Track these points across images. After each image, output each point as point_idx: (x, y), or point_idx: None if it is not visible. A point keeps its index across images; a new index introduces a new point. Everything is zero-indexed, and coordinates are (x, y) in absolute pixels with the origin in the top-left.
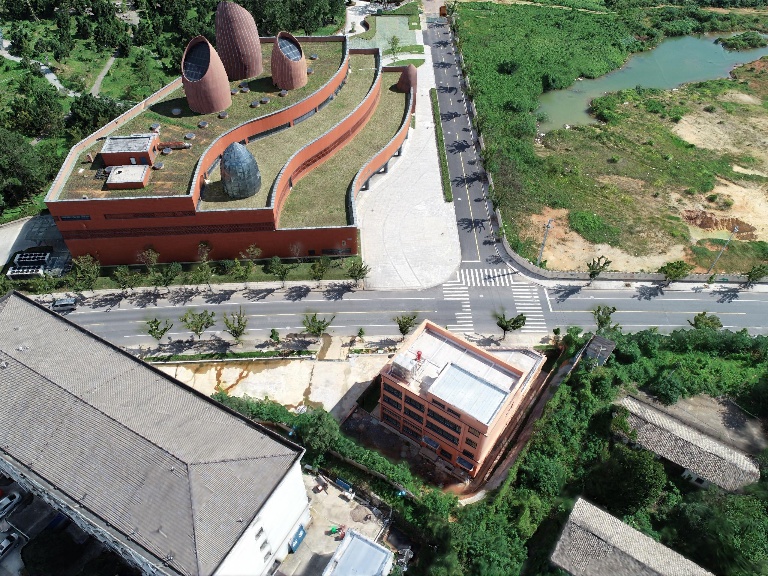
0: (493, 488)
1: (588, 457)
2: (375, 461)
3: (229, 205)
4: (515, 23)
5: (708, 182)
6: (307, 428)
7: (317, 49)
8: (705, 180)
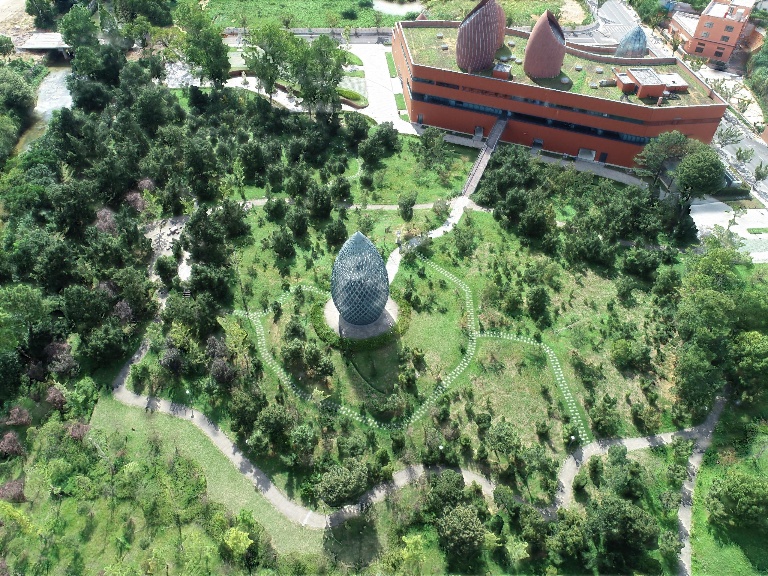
0: (753, 27)
1: None
2: None
3: None
4: (253, 8)
5: None
6: None
7: (420, 37)
8: None
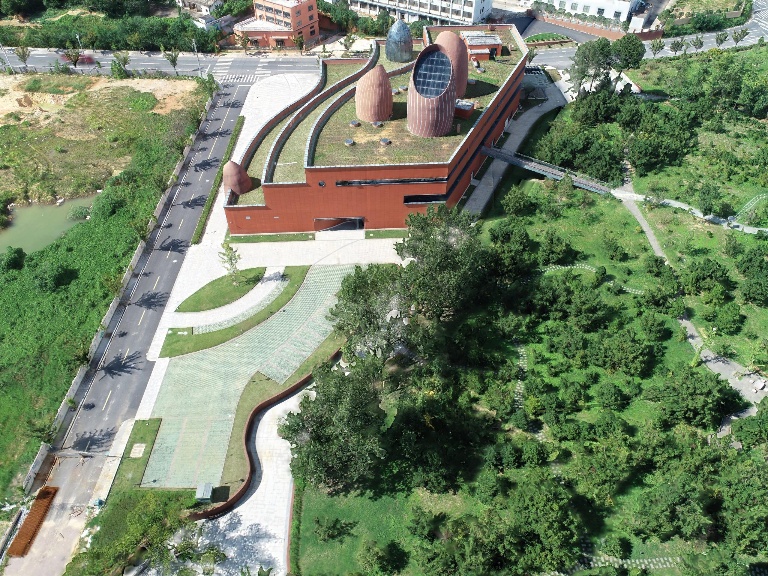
0: None
1: (239, 1)
2: (323, 0)
3: None
4: None
5: (1, 128)
6: None
7: (347, 158)
8: (0, 131)
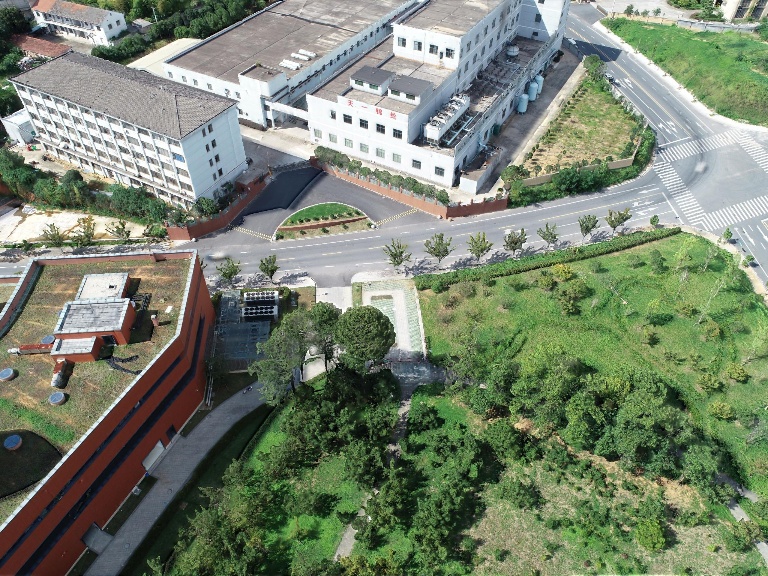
0: None
1: None
2: None
3: (2, 297)
4: None
5: None
6: (23, 167)
7: None
8: None
